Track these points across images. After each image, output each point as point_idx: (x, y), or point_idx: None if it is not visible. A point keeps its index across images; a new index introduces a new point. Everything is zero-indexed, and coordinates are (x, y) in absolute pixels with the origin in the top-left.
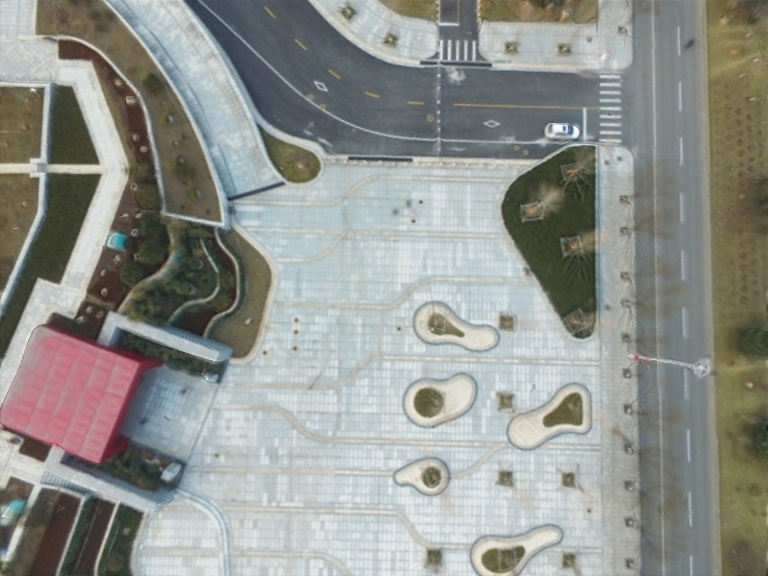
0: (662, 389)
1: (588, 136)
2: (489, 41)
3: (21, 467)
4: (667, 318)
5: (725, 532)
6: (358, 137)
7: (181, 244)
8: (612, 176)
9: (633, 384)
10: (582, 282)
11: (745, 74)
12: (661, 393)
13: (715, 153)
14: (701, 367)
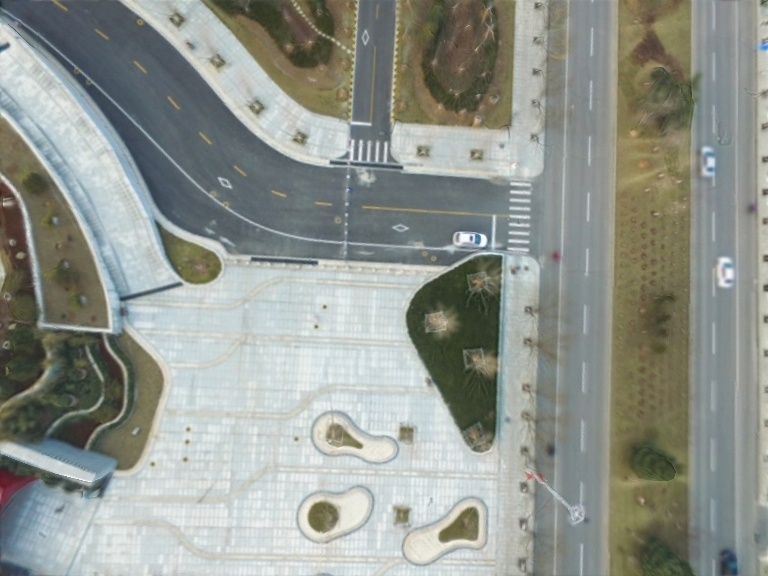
0: (558, 503)
1: (496, 244)
2: (401, 143)
3: None
4: (566, 431)
5: None
6: (262, 237)
7: (59, 356)
8: (518, 286)
9: (530, 498)
10: (482, 396)
11: (650, 189)
12: (557, 507)
13: (619, 266)
14: (577, 514)
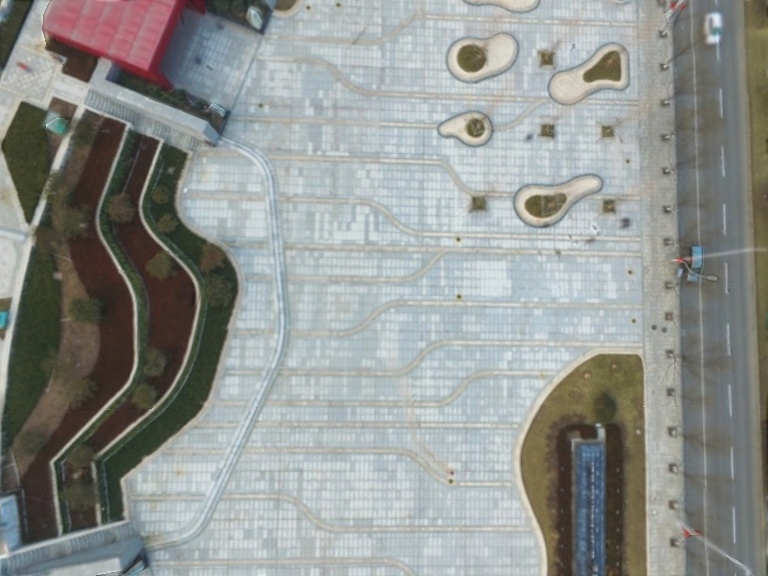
0: (696, 51)
1: None
2: None
3: (64, 88)
4: None
5: (756, 180)
6: None
7: None
8: None
9: (669, 44)
10: None
11: None
12: (695, 54)
13: None
14: None
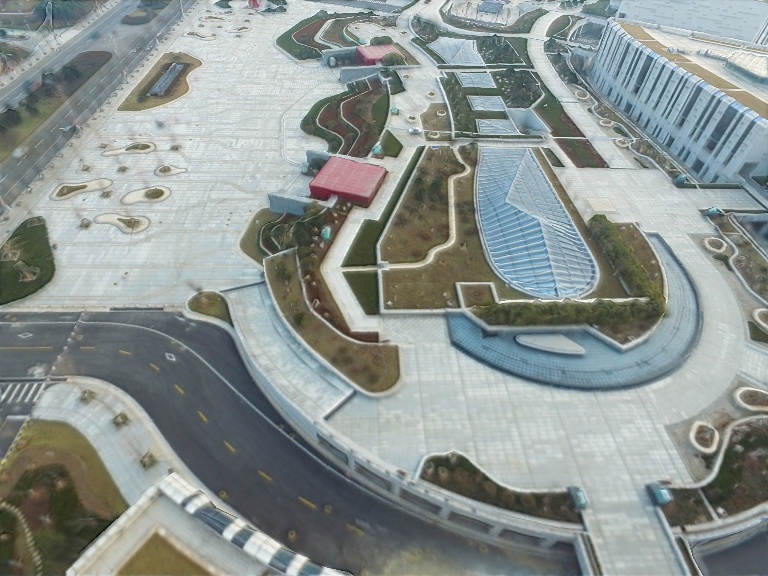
0: None
1: None
2: None
3: (378, 162)
4: None
5: (8, 153)
6: (150, 322)
7: None
8: None
9: None
10: None
11: None
12: None
13: None
14: None
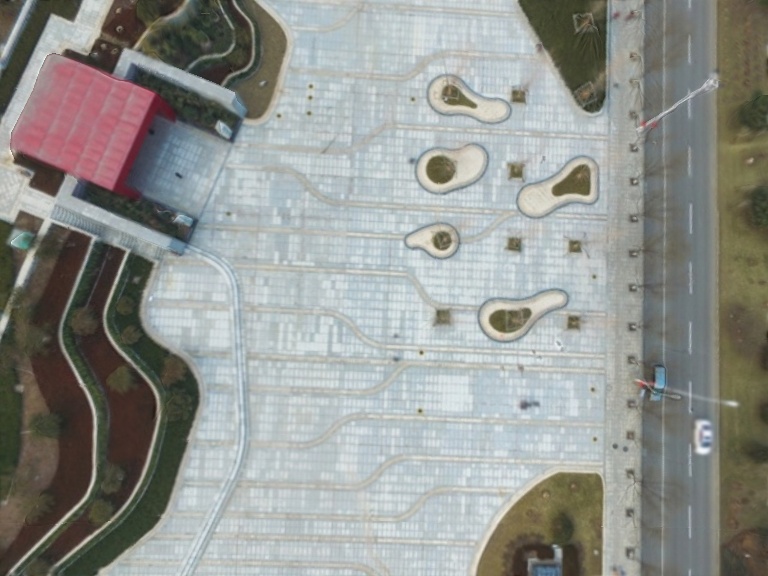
0: (667, 165)
1: None
2: None
3: (31, 202)
4: (673, 98)
5: (723, 299)
6: None
7: None
8: None
9: (639, 158)
10: (593, 55)
11: None
12: (666, 169)
13: None
14: (712, 81)
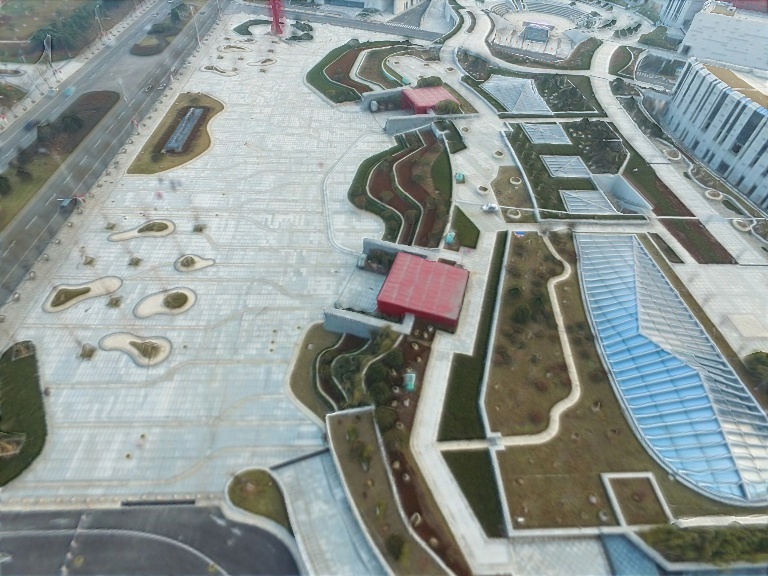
0: None
1: None
2: None
3: (453, 256)
4: None
5: None
6: (177, 529)
7: None
8: None
9: (1, 313)
10: None
11: None
12: None
13: None
14: None
